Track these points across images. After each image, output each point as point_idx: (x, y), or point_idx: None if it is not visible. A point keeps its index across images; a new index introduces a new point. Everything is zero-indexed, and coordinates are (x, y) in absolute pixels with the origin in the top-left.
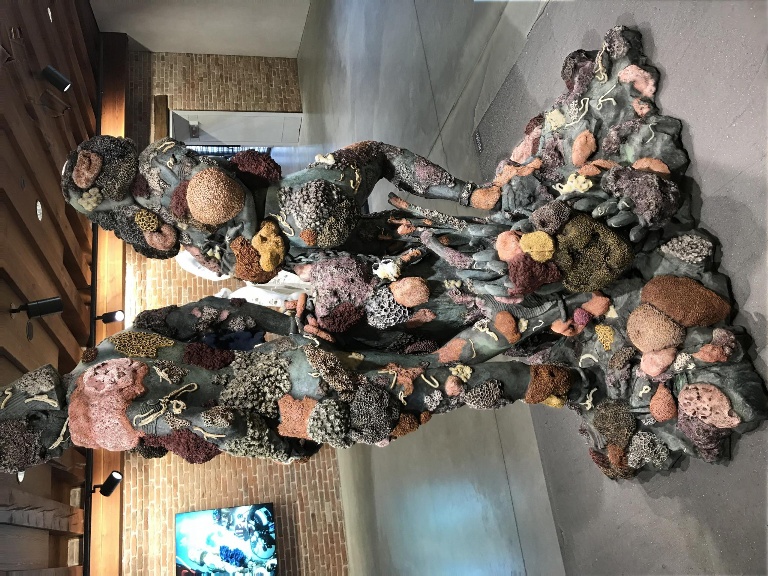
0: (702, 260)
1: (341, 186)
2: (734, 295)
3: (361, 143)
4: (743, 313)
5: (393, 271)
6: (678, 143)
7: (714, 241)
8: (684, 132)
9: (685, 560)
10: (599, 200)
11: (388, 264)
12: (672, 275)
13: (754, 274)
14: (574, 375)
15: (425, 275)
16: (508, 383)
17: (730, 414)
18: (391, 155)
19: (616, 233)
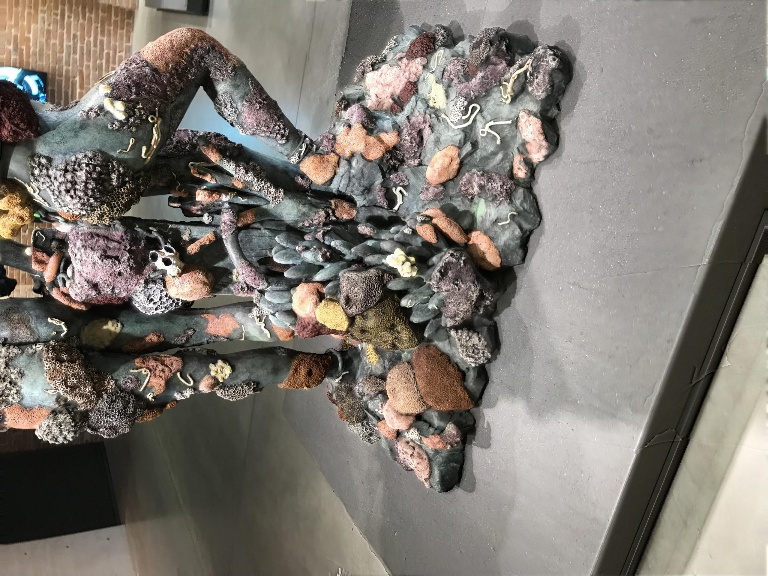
0: (475, 366)
1: (126, 160)
2: (484, 395)
3: (177, 48)
4: (481, 412)
5: (172, 272)
6: (525, 240)
7: (497, 345)
8: (537, 232)
9: (362, 475)
10: (417, 282)
11: (168, 267)
12: (447, 357)
13: (504, 401)
14: (332, 364)
15: (213, 260)
16: (264, 382)
17: (426, 480)
18: (216, 74)
19: (413, 329)
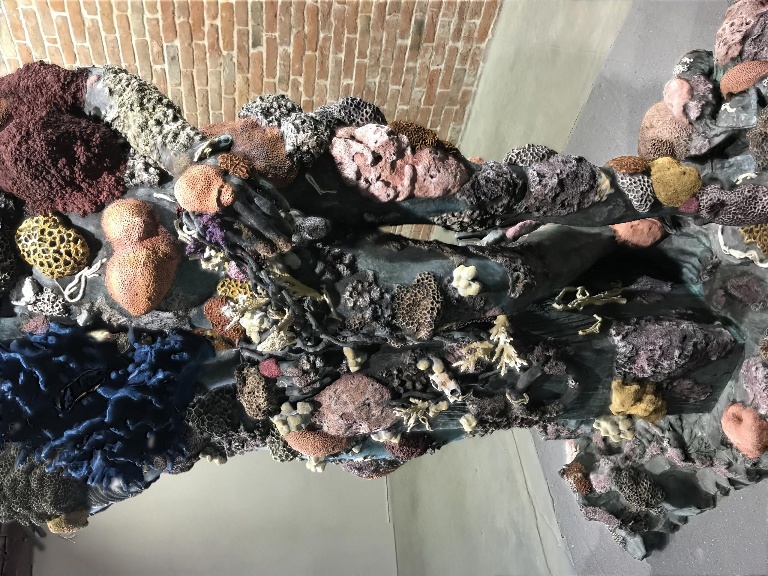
0: None
1: None
2: None
3: None
4: None
5: None
6: None
7: None
8: None
9: None
10: None
11: None
12: None
13: None
14: None
15: None
16: None
17: (738, 1)
18: None
19: None
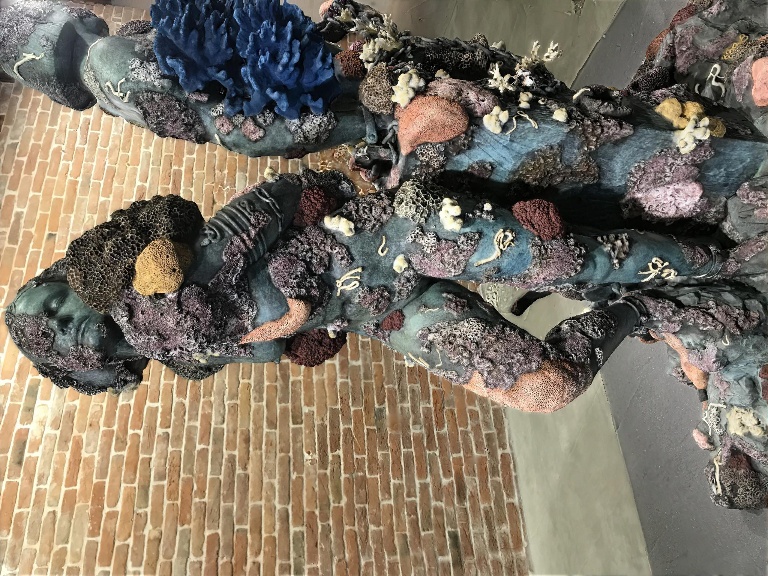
0: None
1: None
2: None
3: None
4: None
5: None
6: None
7: None
8: None
9: None
10: None
11: None
12: None
13: None
14: None
15: None
16: None
17: None
18: None
19: None
